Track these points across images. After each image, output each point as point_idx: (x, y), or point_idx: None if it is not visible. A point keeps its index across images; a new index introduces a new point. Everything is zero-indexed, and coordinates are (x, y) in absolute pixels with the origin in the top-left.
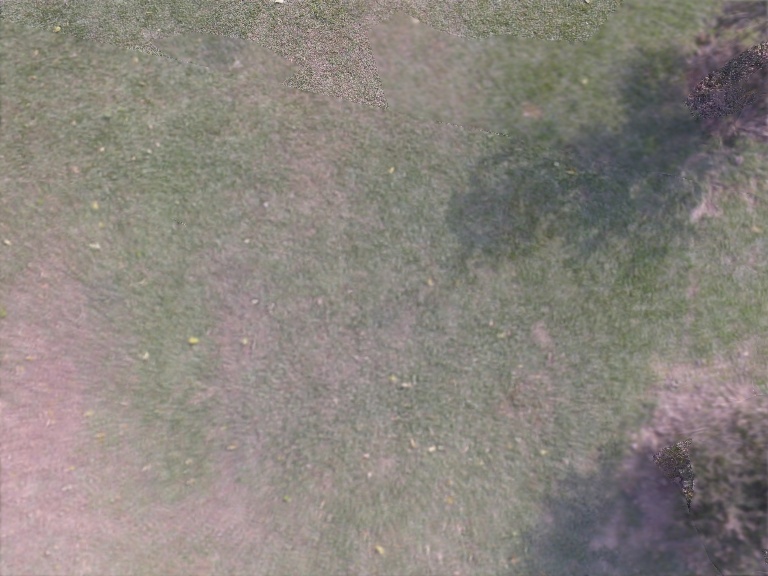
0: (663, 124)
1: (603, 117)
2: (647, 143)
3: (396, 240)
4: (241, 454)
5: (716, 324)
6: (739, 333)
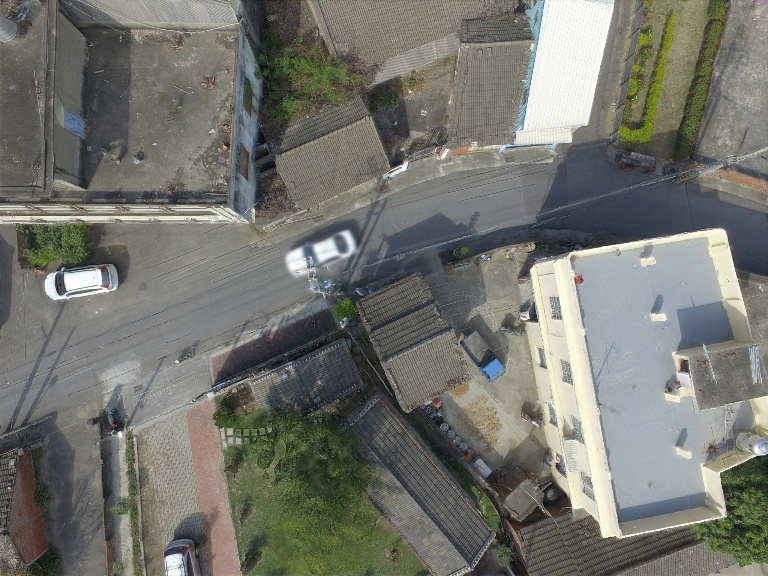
0: None
1: None
2: None
3: (295, 561)
4: None
5: (259, 567)
6: (257, 567)
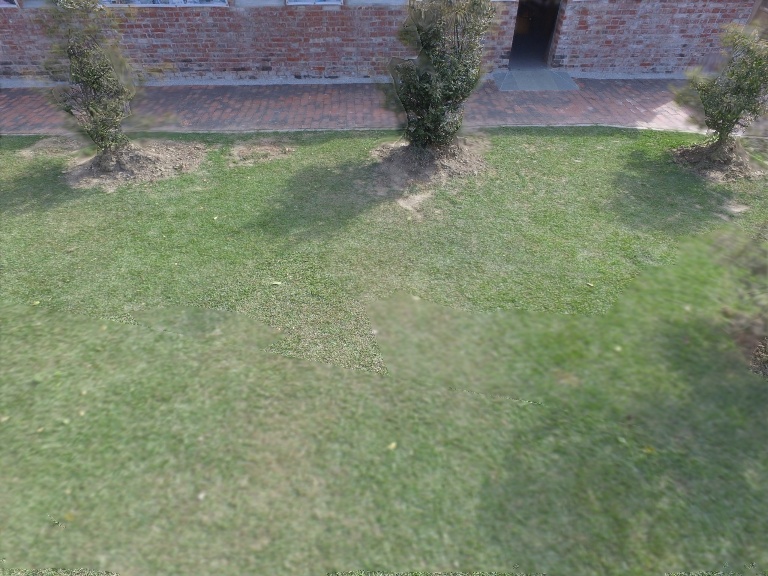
0: (739, 392)
1: (658, 384)
2: (732, 414)
3: (401, 556)
4: None
5: None
6: None
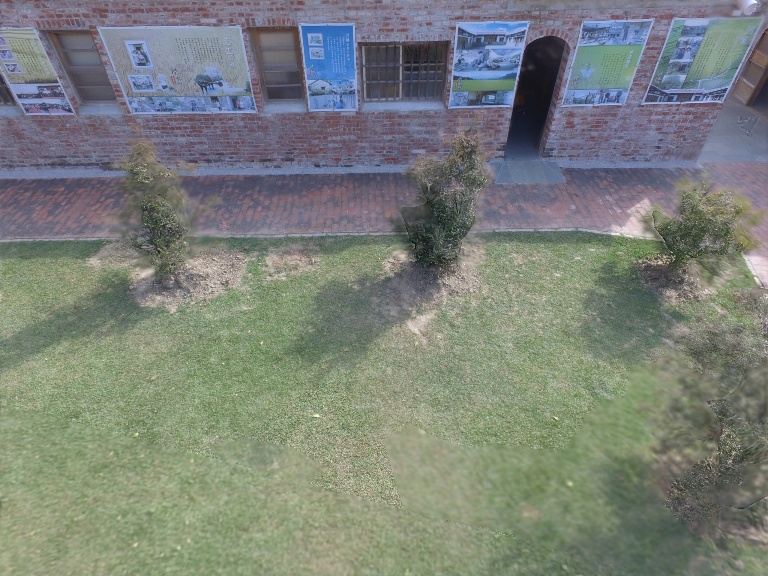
0: (653, 526)
1: (596, 518)
2: (645, 545)
3: None
4: None
5: None
6: None
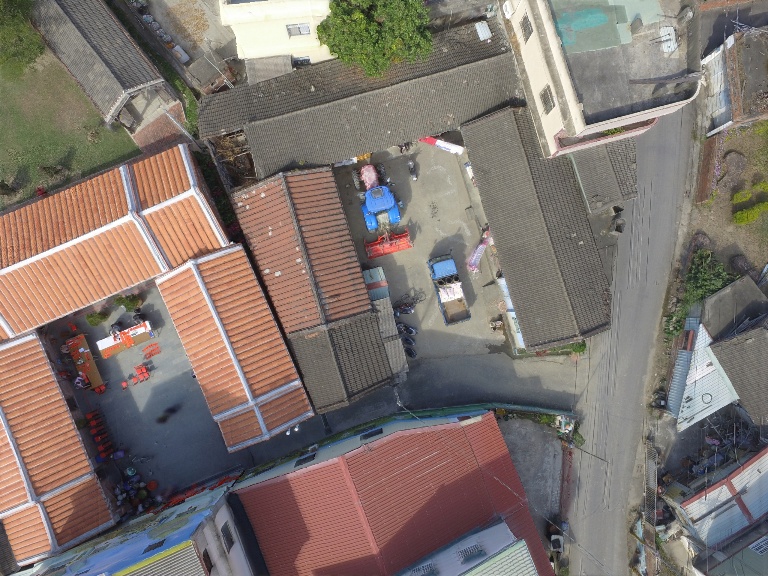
0: None
1: None
2: None
3: None
4: (6, 112)
5: None
6: None
